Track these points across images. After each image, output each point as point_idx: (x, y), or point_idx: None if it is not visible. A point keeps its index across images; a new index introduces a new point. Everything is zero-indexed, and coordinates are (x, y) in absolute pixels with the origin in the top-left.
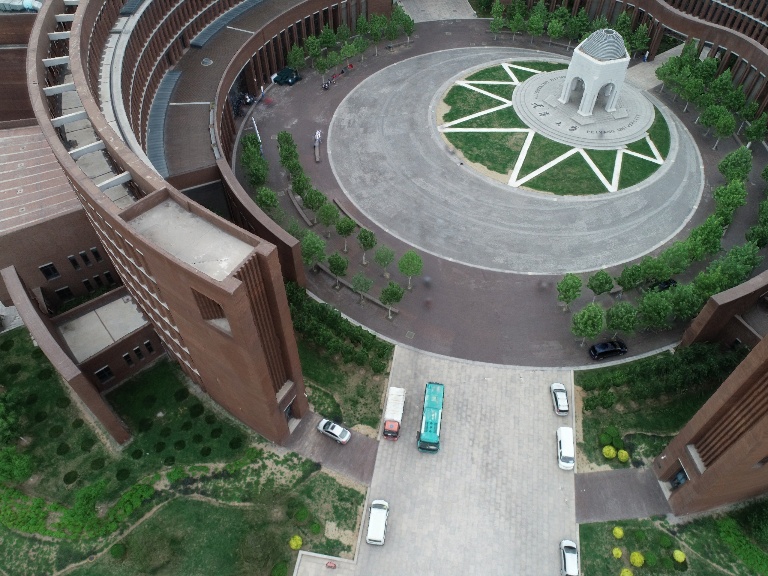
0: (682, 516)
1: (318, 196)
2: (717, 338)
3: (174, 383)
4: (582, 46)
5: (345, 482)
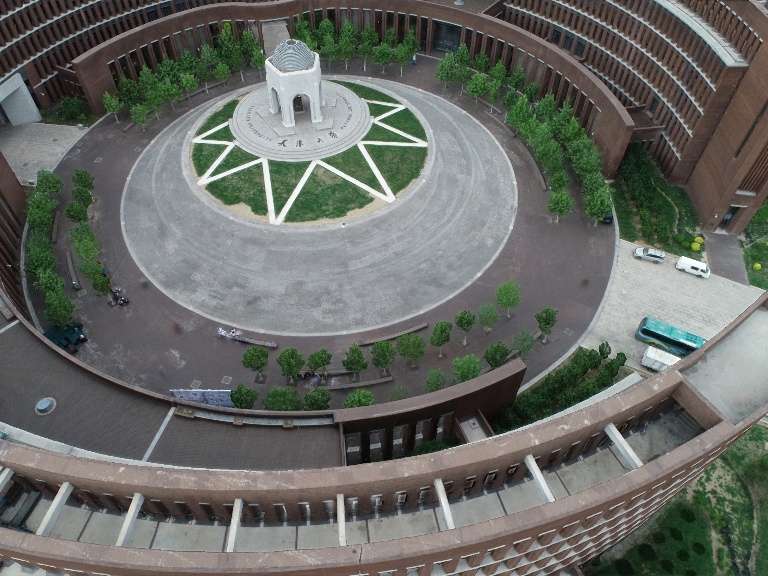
0: None
1: (389, 345)
2: None
3: (607, 575)
4: (281, 68)
5: None
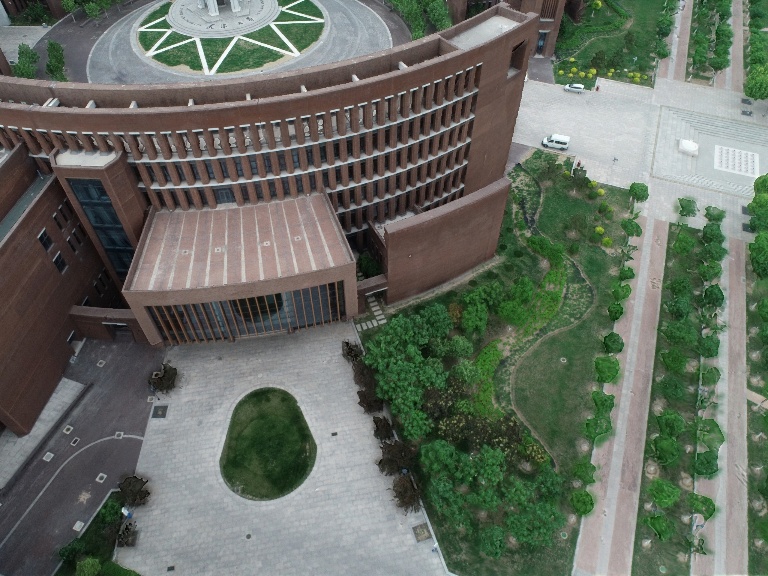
0: (552, 56)
1: None
2: (468, 7)
3: None
4: None
5: (529, 156)
